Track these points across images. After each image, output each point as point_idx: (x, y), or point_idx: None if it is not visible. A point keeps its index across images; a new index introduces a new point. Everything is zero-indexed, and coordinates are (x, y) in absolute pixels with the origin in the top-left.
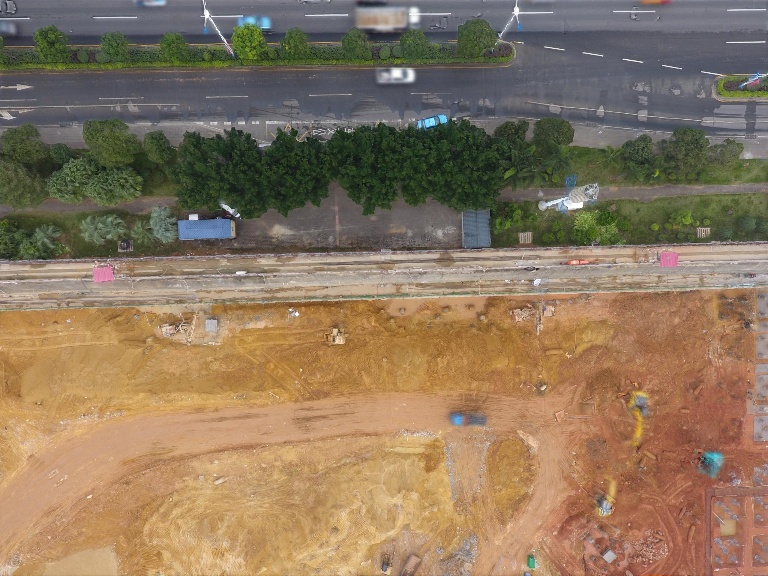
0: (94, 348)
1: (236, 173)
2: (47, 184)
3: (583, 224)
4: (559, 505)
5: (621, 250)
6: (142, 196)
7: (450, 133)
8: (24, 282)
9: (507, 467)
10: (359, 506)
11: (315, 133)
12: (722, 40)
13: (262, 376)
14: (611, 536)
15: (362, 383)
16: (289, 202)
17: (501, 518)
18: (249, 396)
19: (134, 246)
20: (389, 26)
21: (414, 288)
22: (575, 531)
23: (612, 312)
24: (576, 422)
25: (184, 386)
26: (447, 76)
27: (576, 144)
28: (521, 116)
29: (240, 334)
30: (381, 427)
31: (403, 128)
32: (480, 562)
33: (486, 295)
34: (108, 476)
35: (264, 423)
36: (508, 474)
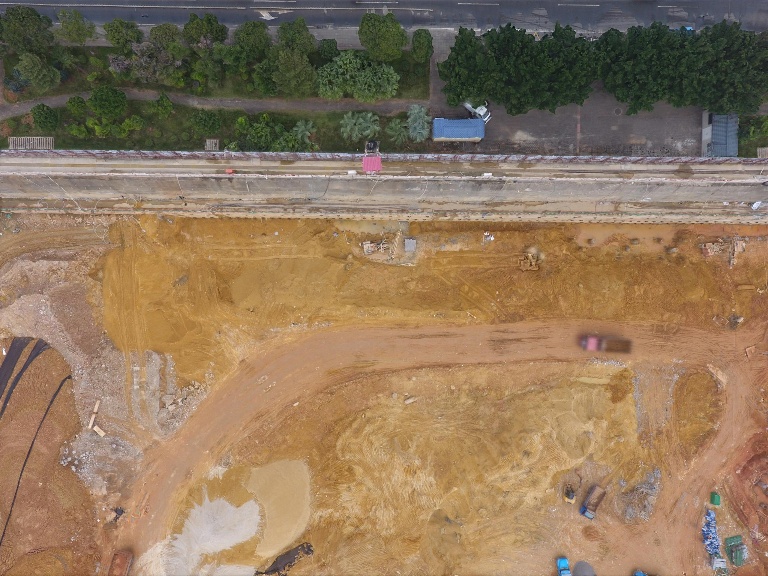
0: (300, 261)
1: (519, 63)
2: (320, 75)
3: None
4: (745, 443)
5: None
6: (392, 98)
7: (722, 34)
8: (274, 178)
9: (693, 402)
10: (550, 431)
11: None
12: None
13: (457, 298)
14: None
15: (558, 307)
16: (561, 97)
17: (685, 453)
18: (448, 315)
19: (380, 147)
20: None
21: (632, 207)
22: (755, 472)
23: None
24: (766, 358)
25: (386, 302)
26: None
27: None
28: None
29: (435, 256)
30: (572, 354)
31: None
32: (662, 497)
33: (703, 217)
34: (314, 385)
35: (461, 343)
36: (693, 409)
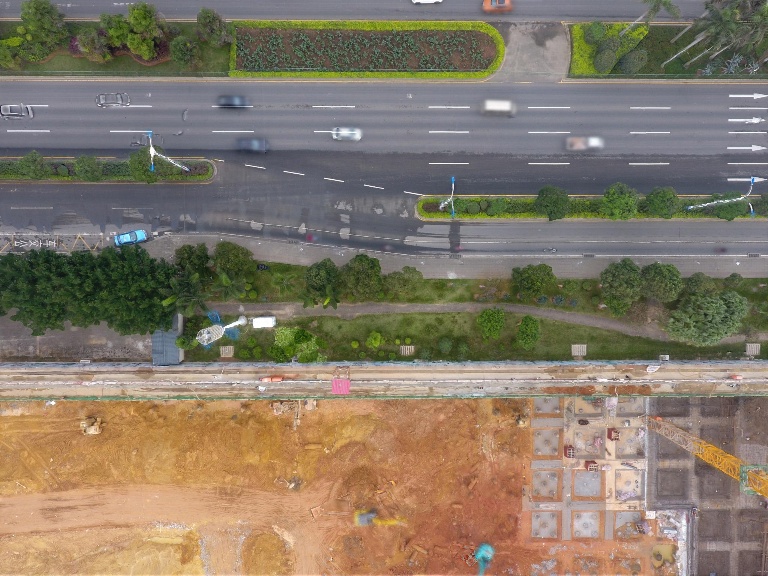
0: None
1: None
2: None
3: (283, 340)
4: None
5: (322, 366)
6: None
7: None
8: None
9: (265, 561)
10: None
11: (17, 245)
12: (425, 161)
13: (15, 464)
14: None
15: (110, 475)
16: None
17: None
18: None
19: None
20: (90, 142)
21: (139, 390)
22: None
23: (377, 407)
24: (333, 518)
25: None
26: (148, 192)
27: (277, 260)
28: (222, 232)
29: None
30: (132, 519)
31: (104, 241)
32: None
33: None
34: None
35: (10, 513)
36: (266, 568)
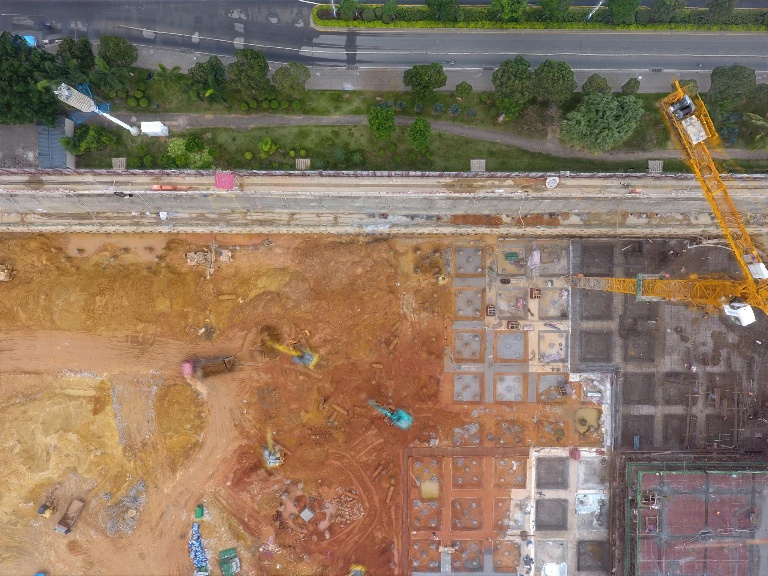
0: None
1: None
2: None
3: (176, 151)
4: (230, 454)
5: None
6: None
7: None
8: None
9: (178, 413)
10: (13, 445)
11: None
12: None
13: None
14: (311, 494)
15: (18, 319)
16: None
17: (172, 466)
18: None
19: None
20: None
21: (39, 218)
22: (255, 484)
23: (294, 260)
24: (246, 369)
25: None
26: None
27: None
28: None
29: None
30: (42, 366)
31: None
32: (148, 510)
33: (114, 228)
34: None
35: None
36: (179, 421)
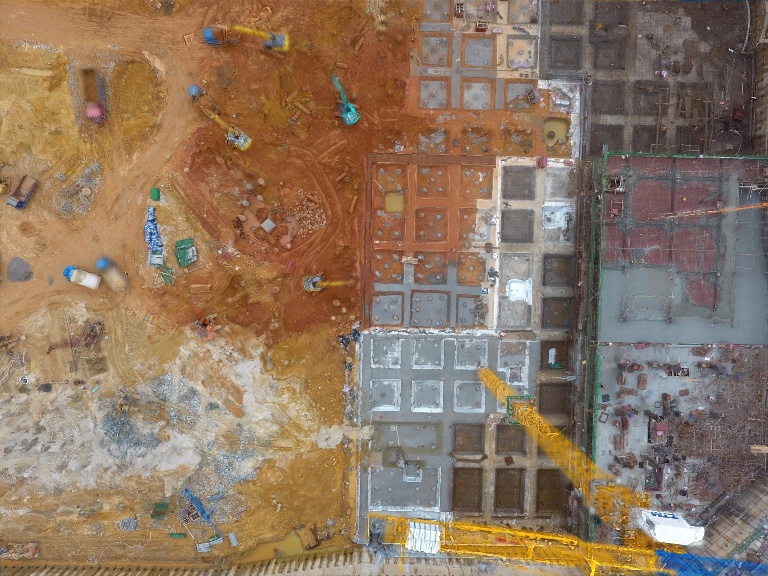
0: None
1: None
2: None
3: None
4: (189, 137)
5: None
6: None
7: None
8: None
9: (136, 95)
10: None
11: None
12: None
13: None
14: (273, 206)
15: None
16: None
17: (128, 149)
18: None
19: None
20: None
21: None
22: (214, 176)
23: None
24: (206, 47)
25: None
26: None
27: None
28: None
29: None
30: None
31: None
32: (103, 192)
33: None
34: None
35: None
36: (137, 102)
